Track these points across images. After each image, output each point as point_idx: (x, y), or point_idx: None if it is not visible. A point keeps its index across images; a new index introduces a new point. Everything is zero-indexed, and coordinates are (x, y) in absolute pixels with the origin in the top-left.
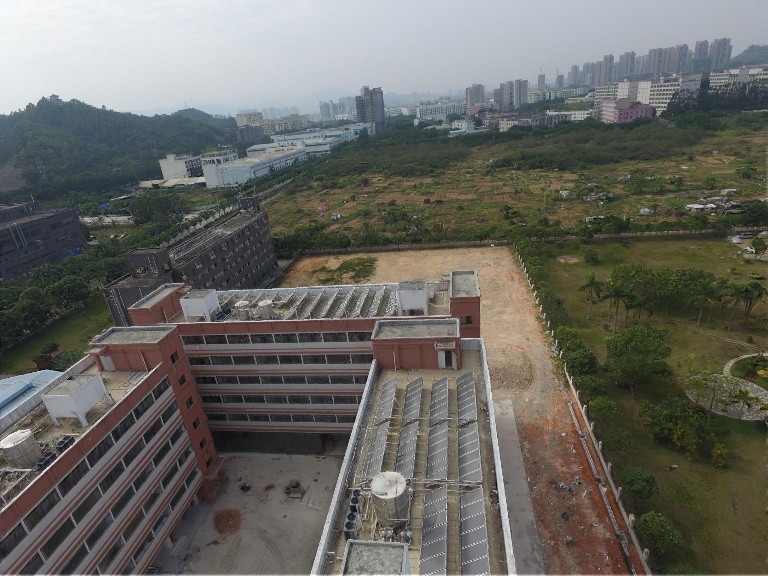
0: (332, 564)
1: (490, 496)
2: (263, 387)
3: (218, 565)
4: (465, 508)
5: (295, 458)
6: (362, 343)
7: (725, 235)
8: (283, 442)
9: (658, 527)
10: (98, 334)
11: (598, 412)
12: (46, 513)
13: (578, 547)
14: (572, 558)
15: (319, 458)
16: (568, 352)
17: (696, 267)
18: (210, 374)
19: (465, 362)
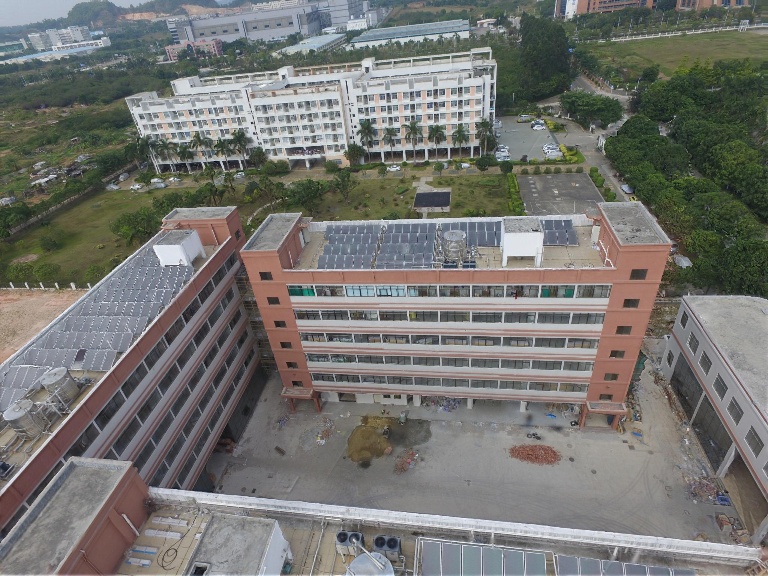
0: None
1: None
2: None
3: None
4: None
5: None
6: (195, 316)
7: (101, 188)
8: None
9: None
10: None
11: None
12: None
13: None
14: None
15: None
16: None
17: (130, 209)
18: None
19: None
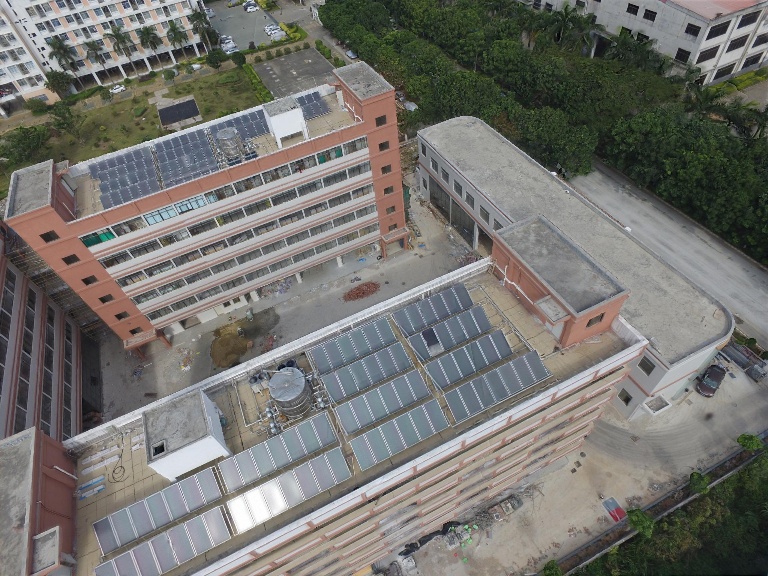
0: None
1: None
2: None
3: None
4: None
5: None
6: None
7: None
8: None
9: None
10: None
11: None
12: None
13: None
14: None
15: None
16: None
17: None
18: None
19: None
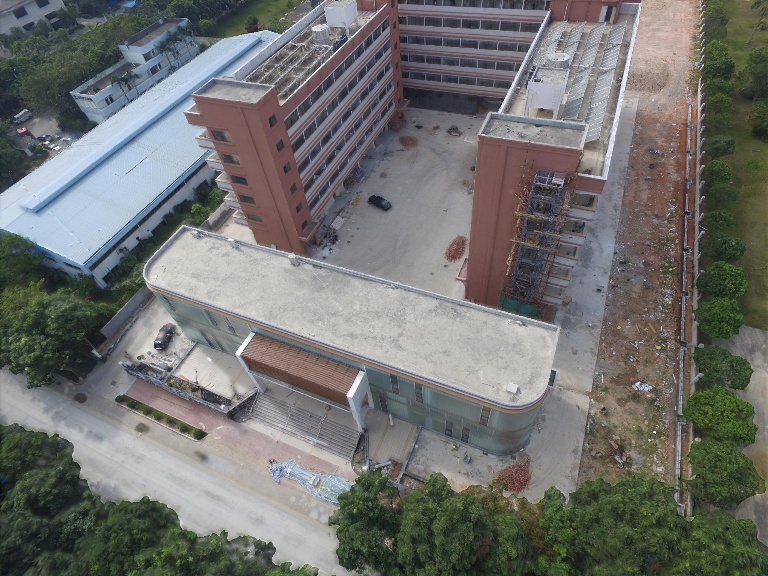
0: (517, 94)
1: (616, 80)
2: (443, 49)
3: (406, 160)
4: (600, 79)
5: (454, 115)
6: (534, 11)
7: None
8: (447, 101)
9: (719, 166)
10: (282, 17)
11: (713, 105)
12: (340, 75)
13: (653, 182)
14: (646, 186)
15: (472, 117)
16: (710, 62)
17: None
18: (404, 33)
19: (620, 20)
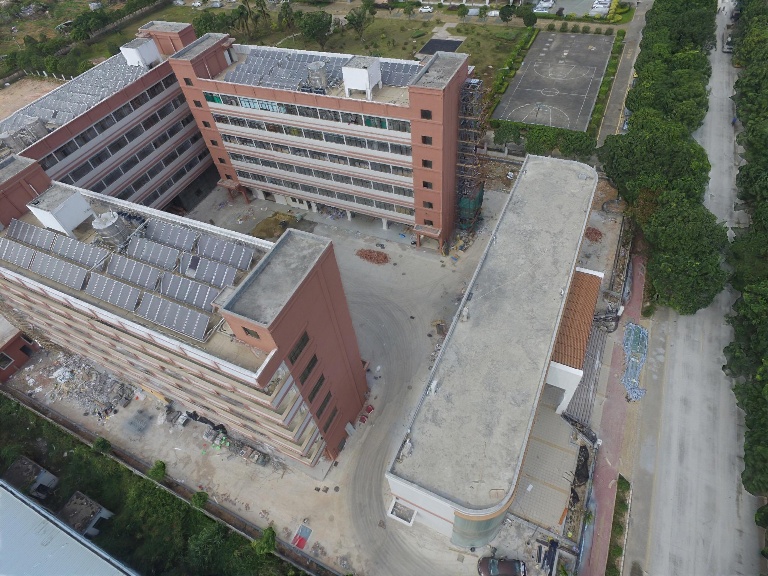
0: None
1: None
2: None
3: None
4: None
5: None
6: (143, 107)
7: (170, 2)
8: None
9: None
10: None
11: None
12: None
13: None
14: None
15: None
16: None
17: None
18: None
19: None
